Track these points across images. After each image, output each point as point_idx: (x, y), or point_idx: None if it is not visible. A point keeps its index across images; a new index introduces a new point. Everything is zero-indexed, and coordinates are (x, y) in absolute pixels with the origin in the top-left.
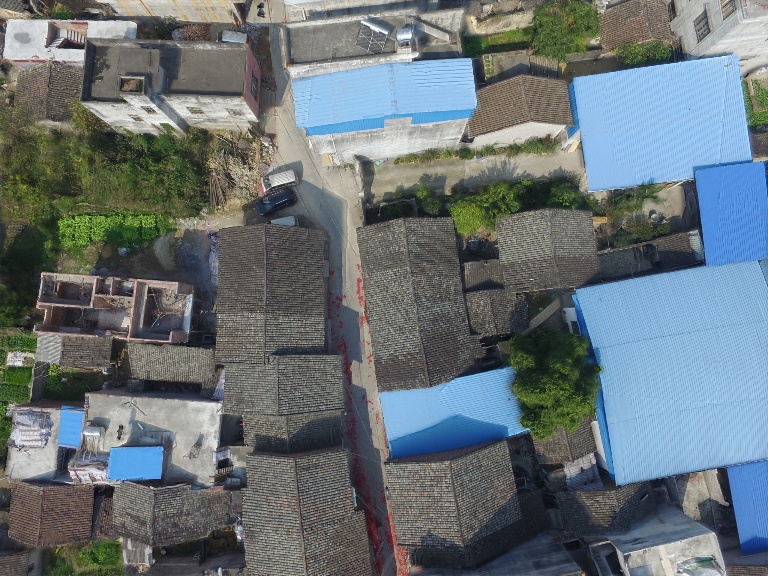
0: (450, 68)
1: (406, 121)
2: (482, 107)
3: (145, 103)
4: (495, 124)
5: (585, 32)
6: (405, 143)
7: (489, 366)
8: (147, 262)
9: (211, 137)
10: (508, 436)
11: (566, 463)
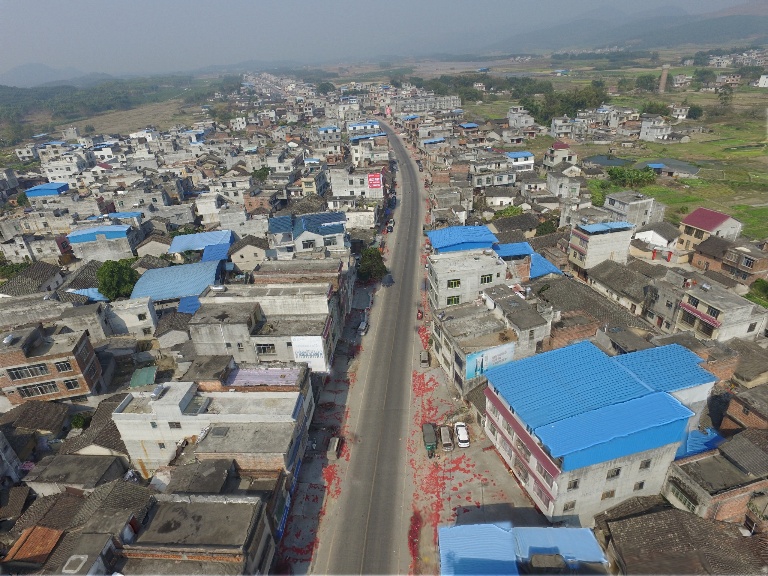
0: None
1: (104, 237)
2: None
3: (21, 242)
4: None
5: (186, 231)
6: (111, 254)
7: None
8: None
9: None
10: (93, 300)
11: None
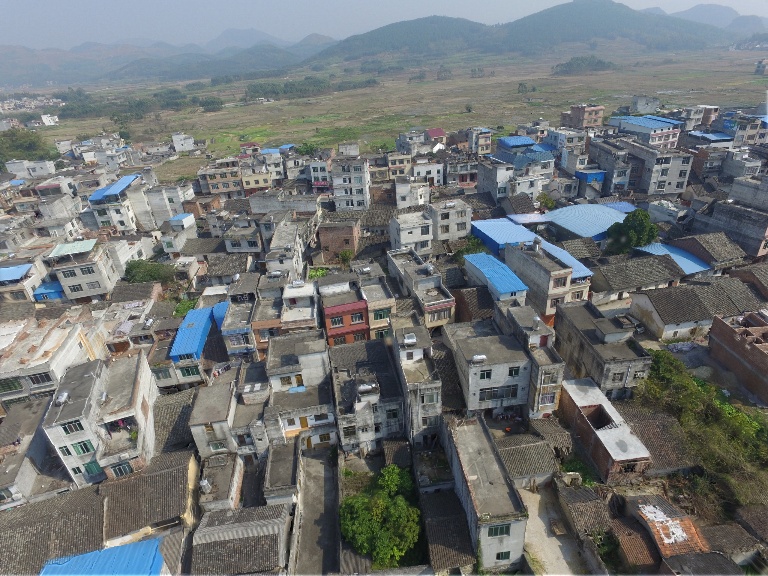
0: None
1: None
2: None
3: None
4: None
5: None
6: None
7: (638, 256)
8: (719, 381)
9: None
10: None
11: None
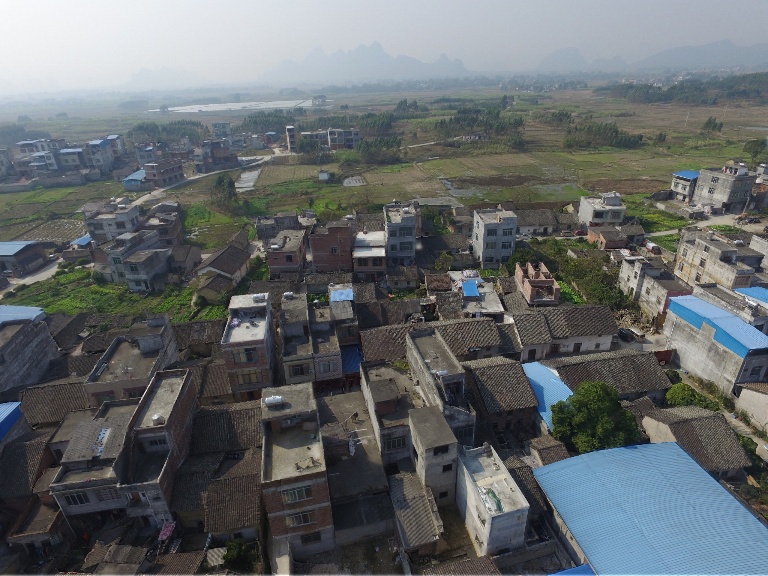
0: (763, 337)
1: (712, 333)
2: (765, 385)
3: (638, 270)
4: (759, 388)
5: None
6: None
7: None
8: None
9: (638, 310)
10: None
11: (531, 457)
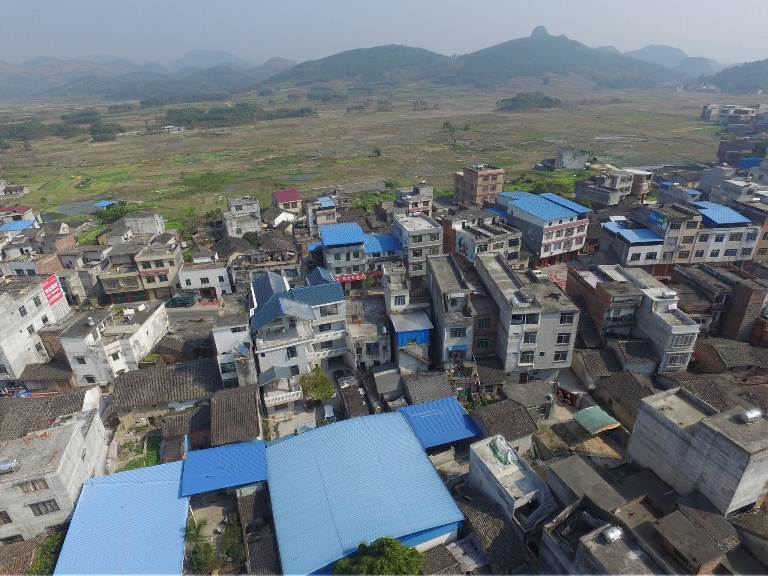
0: None
1: None
2: None
3: None
4: None
5: None
6: None
7: None
8: None
9: None
10: None
11: (464, 570)
